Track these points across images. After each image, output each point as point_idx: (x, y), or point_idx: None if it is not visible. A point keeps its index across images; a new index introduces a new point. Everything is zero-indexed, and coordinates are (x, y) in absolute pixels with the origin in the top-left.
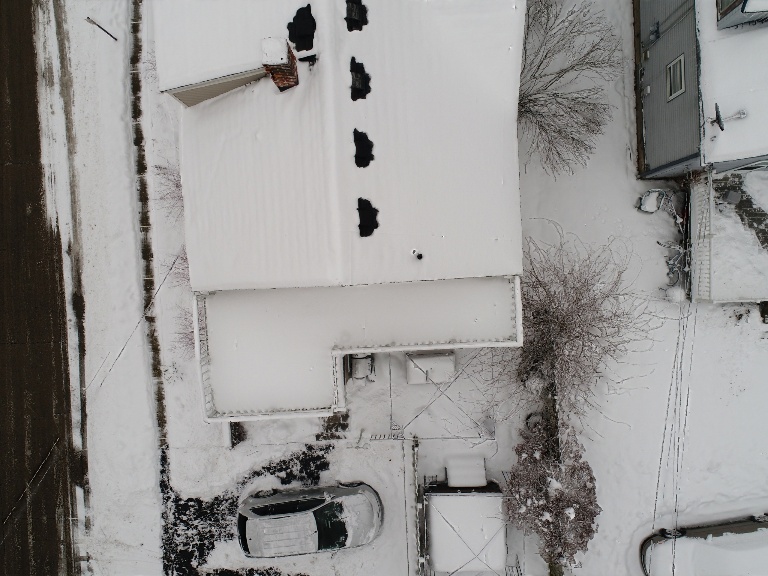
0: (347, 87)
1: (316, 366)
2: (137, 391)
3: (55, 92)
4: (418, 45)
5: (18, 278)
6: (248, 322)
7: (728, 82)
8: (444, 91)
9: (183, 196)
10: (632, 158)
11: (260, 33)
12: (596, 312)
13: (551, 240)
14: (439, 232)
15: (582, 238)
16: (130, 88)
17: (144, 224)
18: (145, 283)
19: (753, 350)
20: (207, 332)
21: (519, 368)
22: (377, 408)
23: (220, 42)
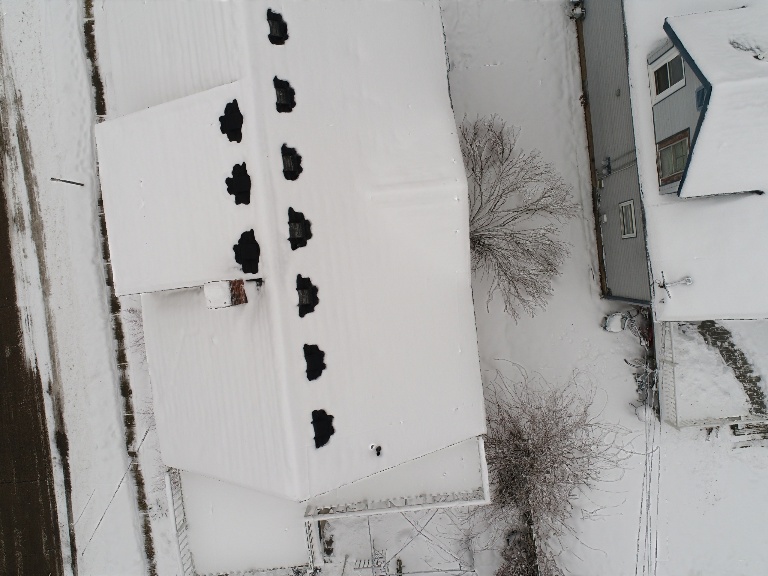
0: (294, 306)
1: (291, 527)
2: (124, 527)
3: (27, 236)
4: (365, 242)
5: (1, 419)
6: (222, 487)
7: (673, 247)
8: (394, 279)
9: (150, 375)
10: (595, 278)
11: (208, 252)
12: (566, 440)
13: (521, 361)
14: (397, 419)
15: (551, 358)
16: (99, 230)
17: (121, 362)
18: (126, 419)
19: (726, 460)
20: (183, 498)
21: (493, 503)
22: (360, 534)
23: (171, 257)
